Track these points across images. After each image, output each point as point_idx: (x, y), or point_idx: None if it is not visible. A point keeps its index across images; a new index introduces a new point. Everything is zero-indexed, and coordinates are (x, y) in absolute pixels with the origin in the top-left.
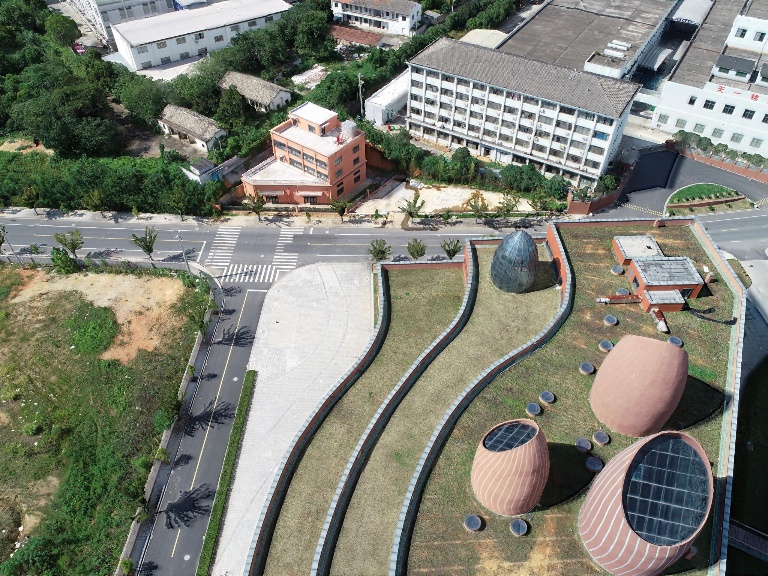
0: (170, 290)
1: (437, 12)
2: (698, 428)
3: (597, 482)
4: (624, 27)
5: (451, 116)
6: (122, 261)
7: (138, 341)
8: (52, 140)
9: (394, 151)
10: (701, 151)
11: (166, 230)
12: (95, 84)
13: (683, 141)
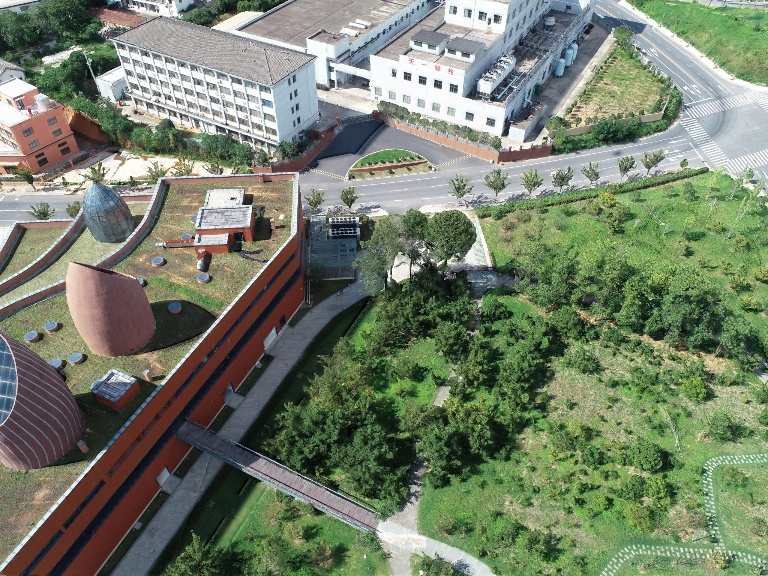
0: None
1: None
2: (173, 348)
3: None
4: (377, 8)
5: (160, 90)
6: None
7: None
8: None
9: (105, 124)
10: (400, 120)
11: None
12: None
13: (384, 111)
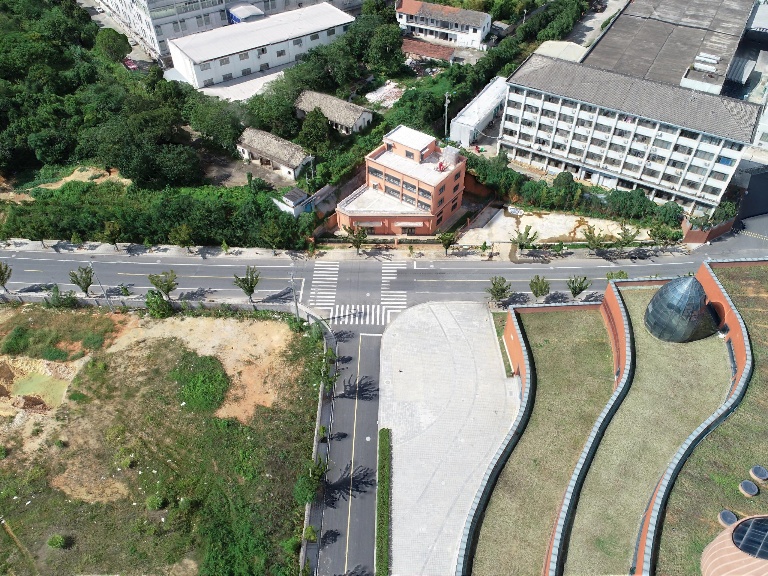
0: (277, 335)
1: (505, 23)
2: None
3: None
4: (707, 38)
5: (551, 138)
6: (221, 303)
7: (253, 395)
8: (132, 170)
9: (491, 176)
10: None
11: (259, 266)
12: (172, 108)
13: None
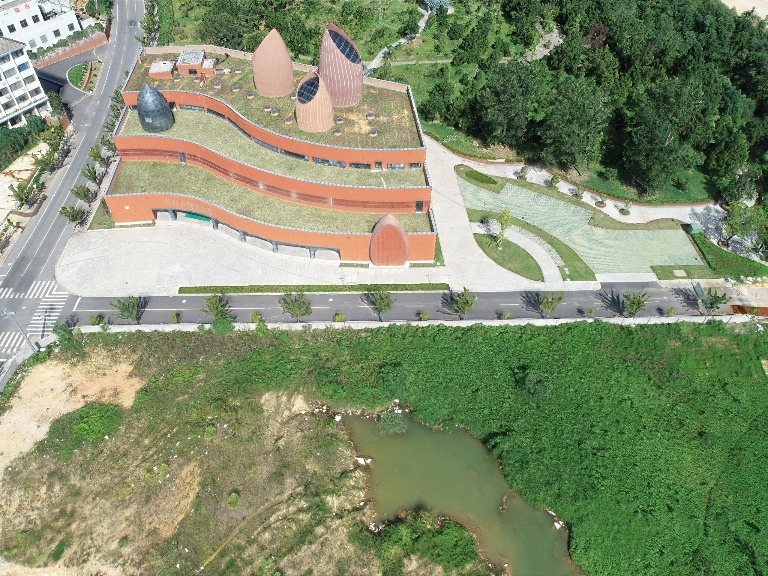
0: (46, 373)
1: None
2: None
3: (332, 74)
4: None
5: None
6: None
7: (116, 381)
8: None
9: None
10: (35, 61)
11: None
12: None
13: None
